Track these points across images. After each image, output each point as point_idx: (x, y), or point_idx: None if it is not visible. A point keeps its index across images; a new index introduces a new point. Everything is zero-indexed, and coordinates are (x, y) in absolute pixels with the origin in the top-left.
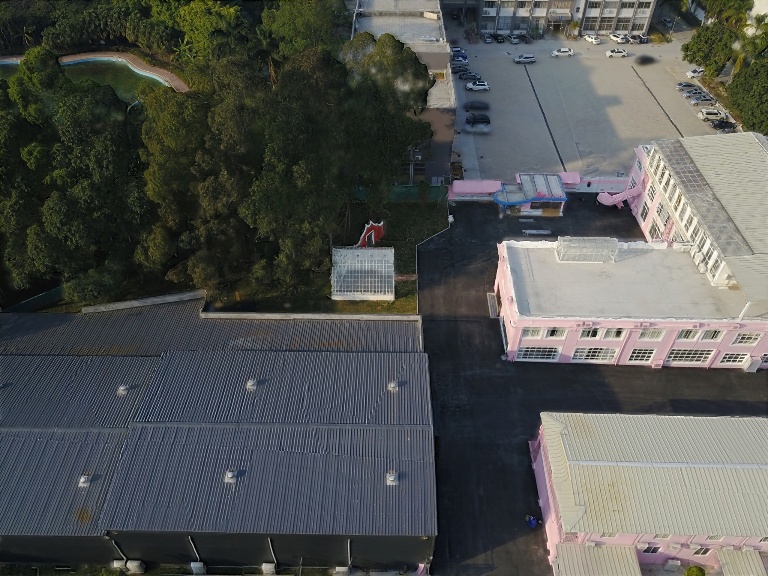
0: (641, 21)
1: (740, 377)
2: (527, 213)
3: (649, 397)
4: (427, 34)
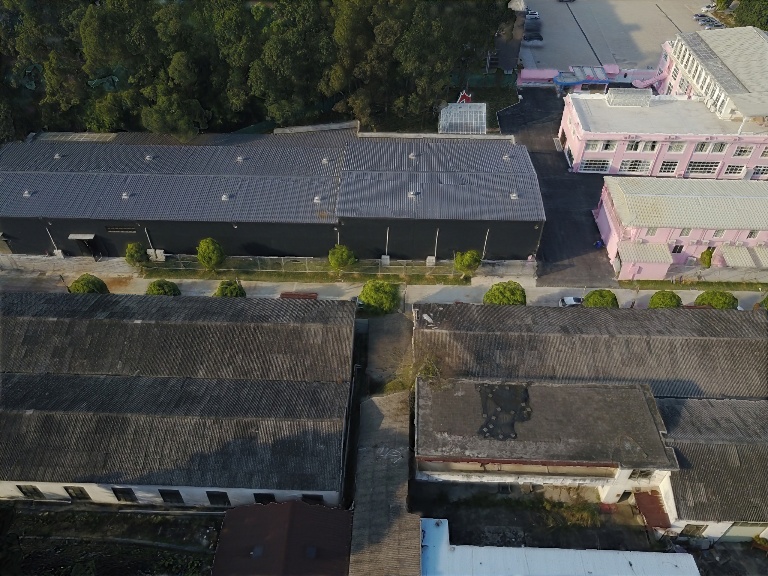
0: None
1: None
2: None
3: None
4: None
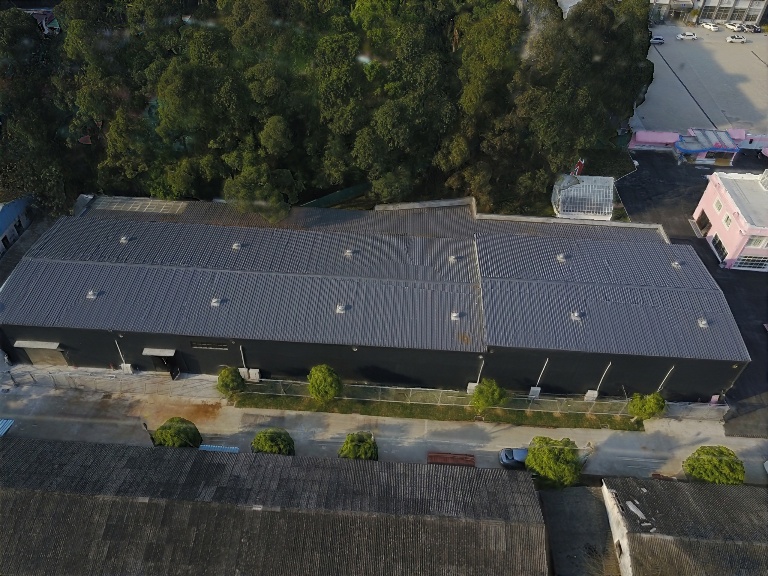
0: (755, 12)
1: None
2: (701, 162)
3: None
4: None
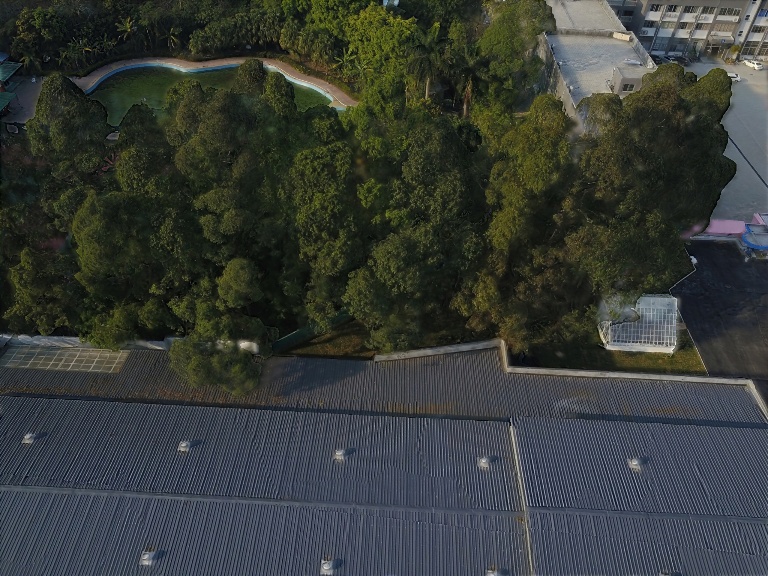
0: None
1: None
2: None
3: None
4: (625, 56)
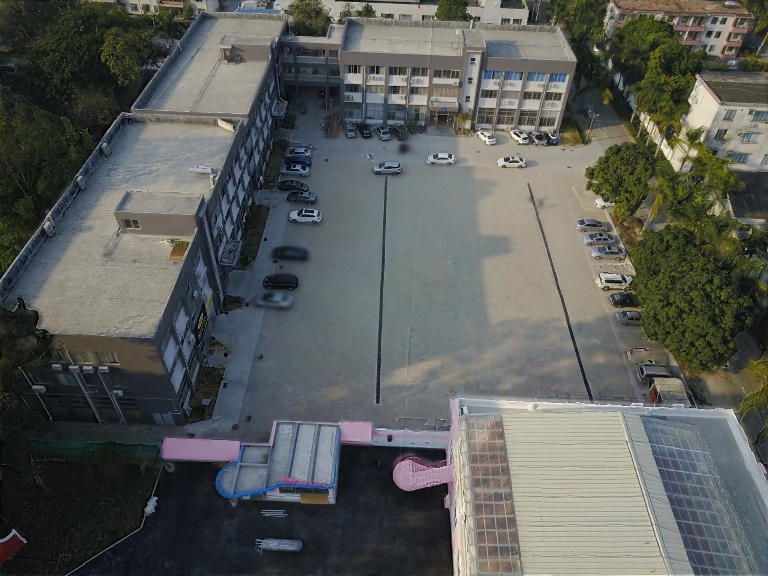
0: (551, 115)
1: None
2: (277, 497)
3: None
4: (208, 159)
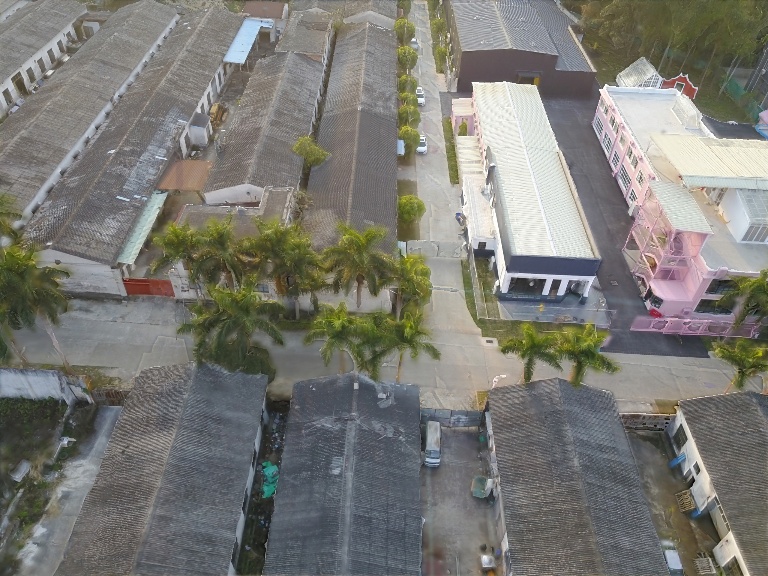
0: None
1: (622, 210)
2: None
3: (585, 168)
4: None
